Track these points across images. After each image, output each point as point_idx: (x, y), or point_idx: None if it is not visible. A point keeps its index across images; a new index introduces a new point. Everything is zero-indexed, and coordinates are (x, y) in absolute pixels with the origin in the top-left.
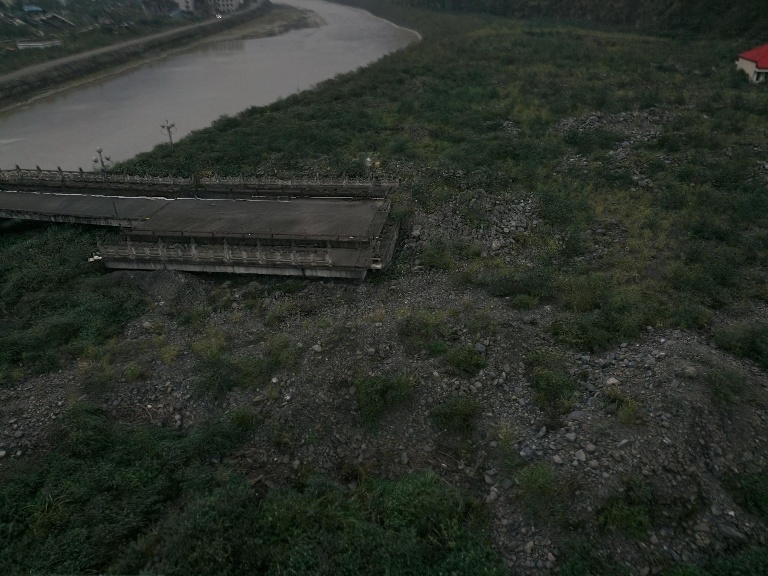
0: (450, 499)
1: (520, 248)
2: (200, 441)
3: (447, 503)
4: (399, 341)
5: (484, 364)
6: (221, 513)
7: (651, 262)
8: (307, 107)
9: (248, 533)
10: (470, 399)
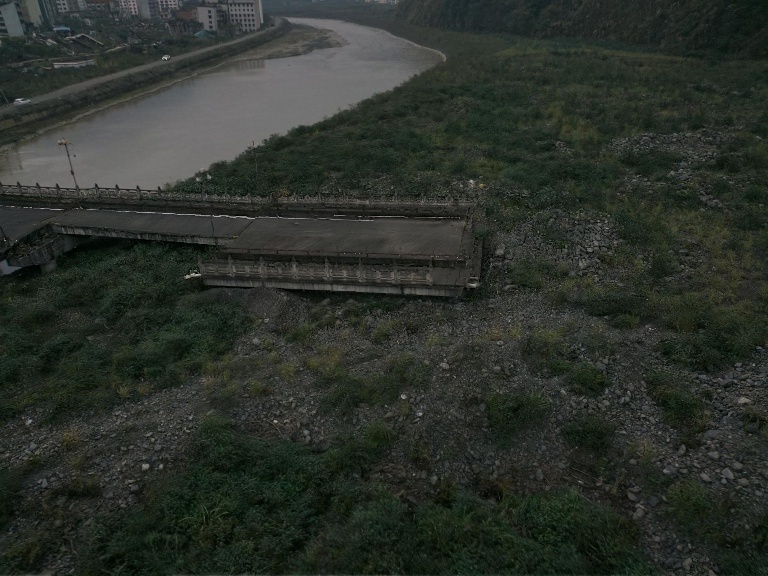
0: (597, 516)
1: (607, 268)
2: (342, 456)
3: (597, 519)
4: (522, 359)
5: (608, 383)
6: (385, 527)
7: (742, 282)
8: (354, 127)
9: (412, 547)
10: (599, 417)
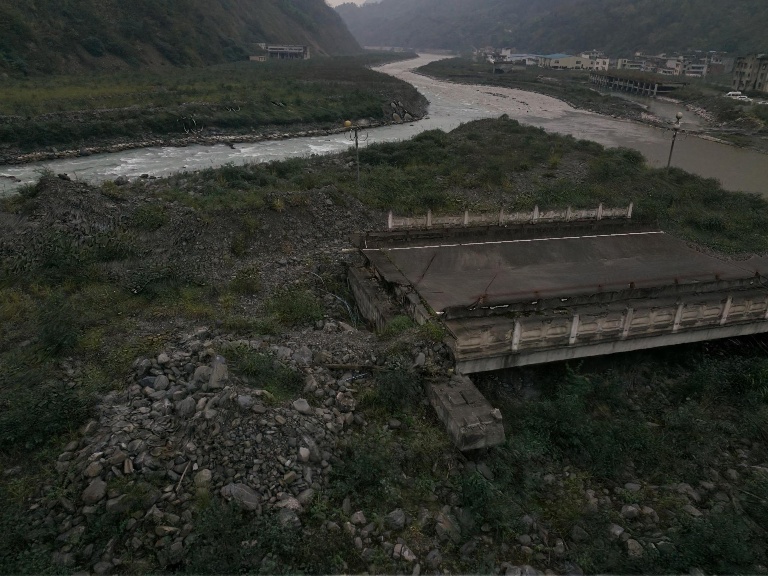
0: None
1: None
2: None
3: None
4: None
5: None
6: None
7: None
8: None
9: None
10: None
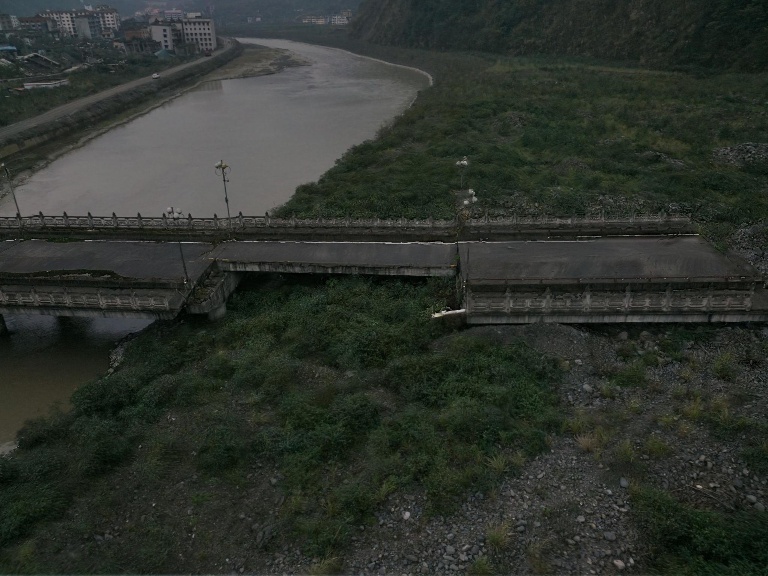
0: None
1: None
2: None
3: None
4: None
5: None
6: None
7: None
8: (421, 143)
9: None
10: None
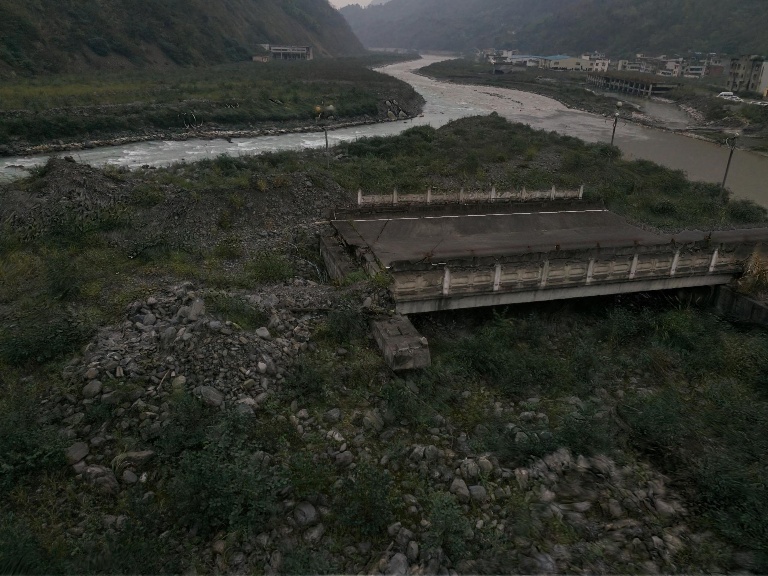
0: None
1: None
2: None
3: None
4: None
5: None
6: None
7: None
8: None
9: None
10: None
